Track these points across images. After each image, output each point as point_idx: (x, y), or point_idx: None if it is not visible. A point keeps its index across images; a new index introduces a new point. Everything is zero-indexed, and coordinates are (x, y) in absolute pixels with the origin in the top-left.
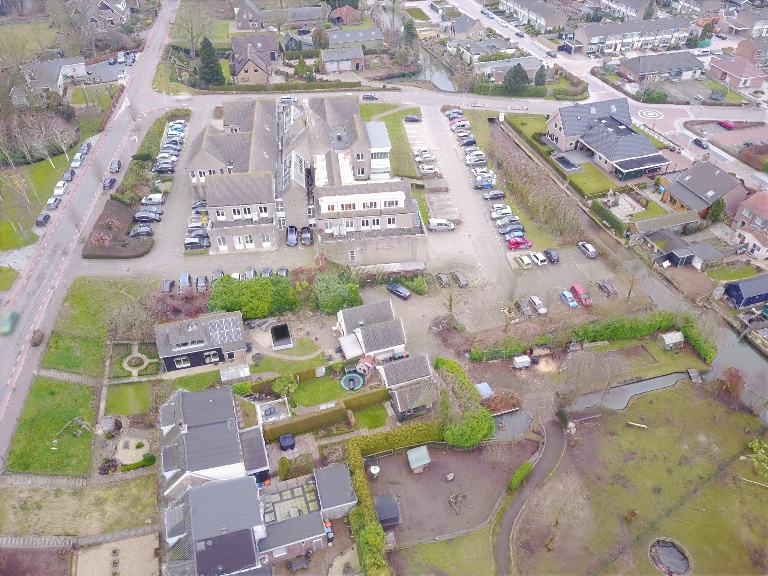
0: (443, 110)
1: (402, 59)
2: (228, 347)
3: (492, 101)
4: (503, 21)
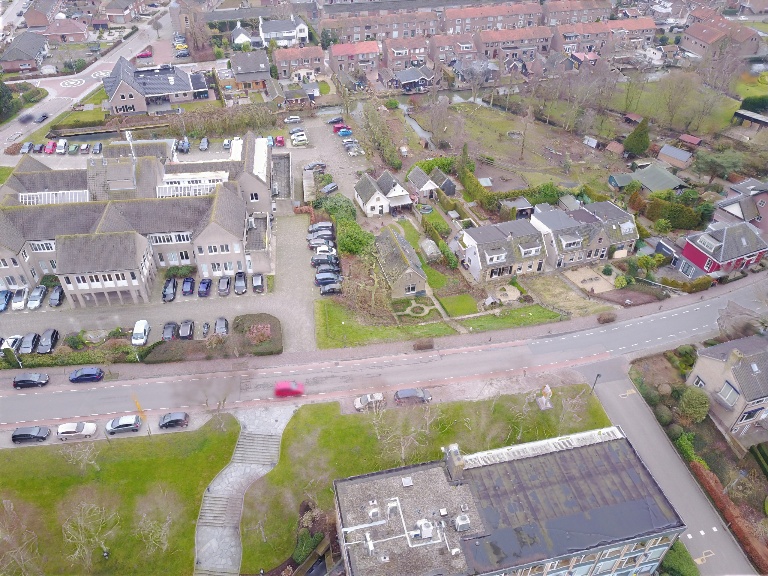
0: (14, 153)
1: None
2: None
3: (10, 130)
4: None
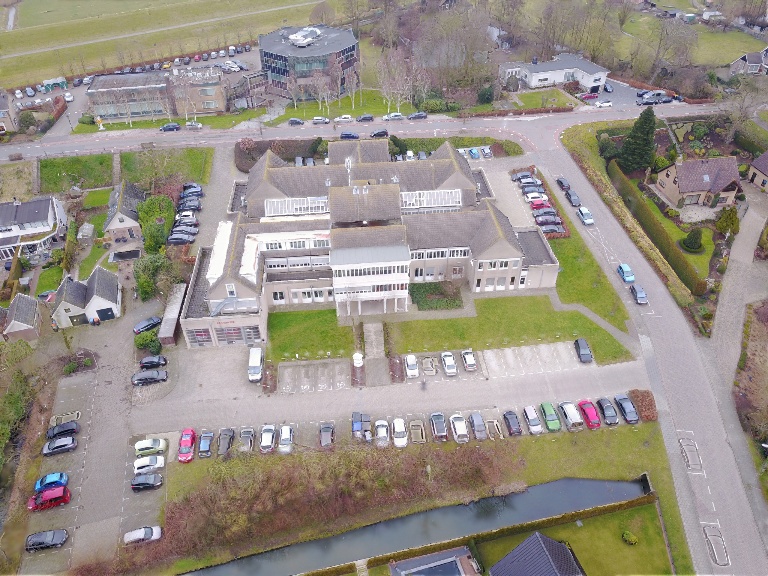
0: (633, 392)
1: None
2: None
3: (734, 490)
4: None
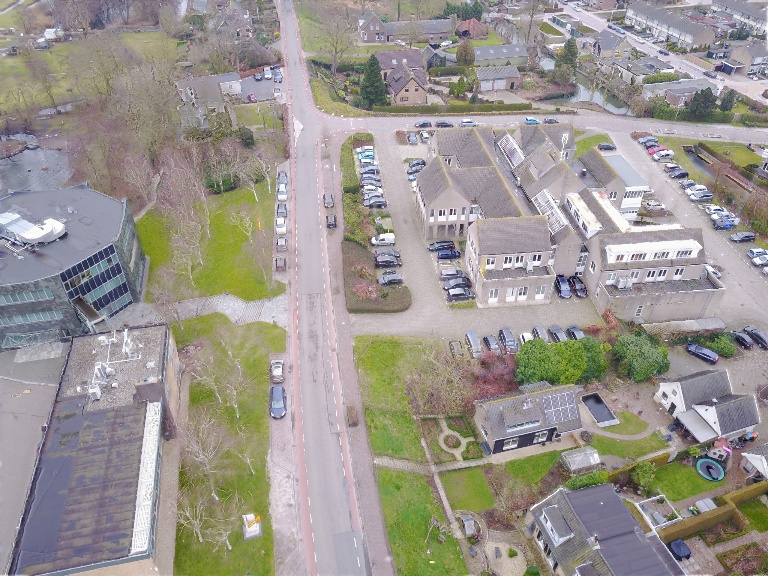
0: (635, 137)
1: (562, 79)
2: (563, 427)
3: (679, 127)
4: (640, 37)
